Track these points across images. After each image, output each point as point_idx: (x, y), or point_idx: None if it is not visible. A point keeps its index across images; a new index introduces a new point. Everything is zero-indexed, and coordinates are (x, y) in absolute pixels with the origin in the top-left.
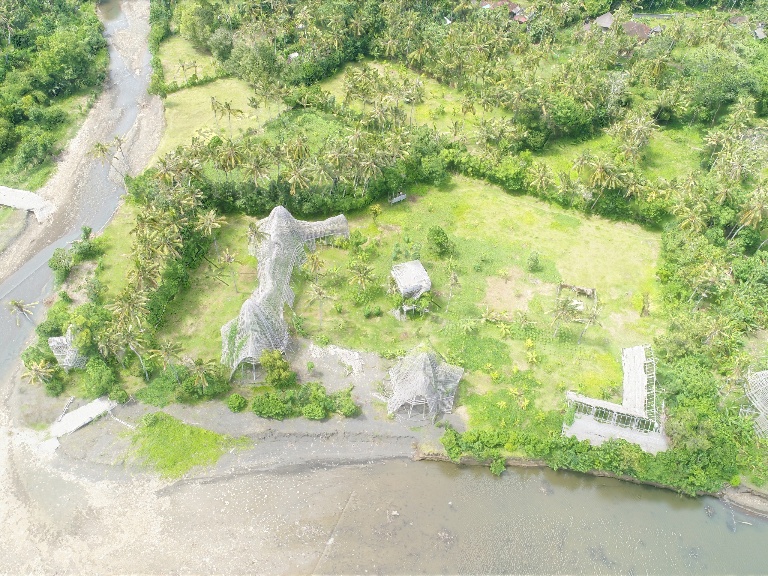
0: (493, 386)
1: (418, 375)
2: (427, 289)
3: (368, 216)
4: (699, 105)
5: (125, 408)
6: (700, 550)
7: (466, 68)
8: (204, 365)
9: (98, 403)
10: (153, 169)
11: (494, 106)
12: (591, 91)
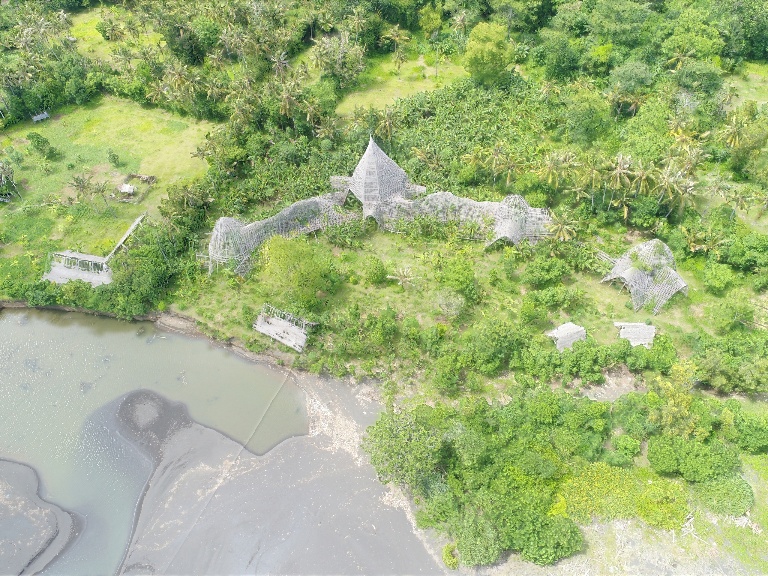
0: (23, 252)
1: None
2: None
3: (10, 133)
4: (337, 20)
5: None
6: (113, 357)
7: (153, 4)
8: None
9: None
10: None
11: None
12: (239, 14)
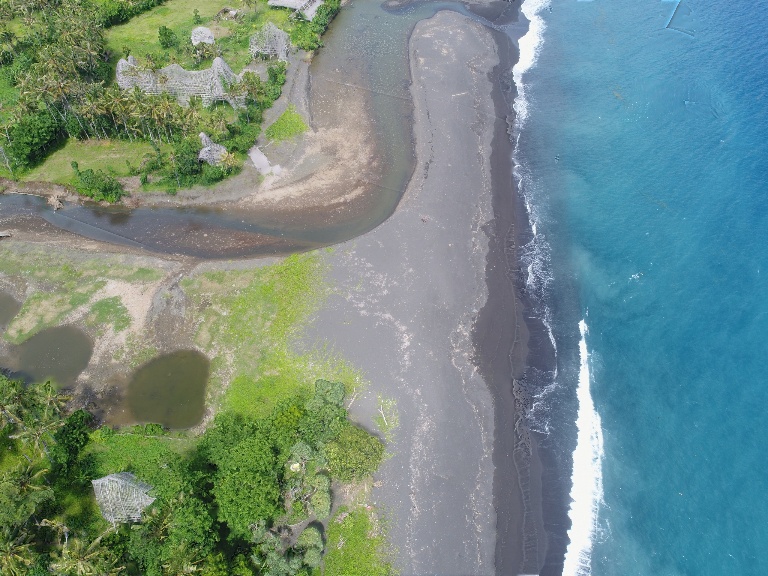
0: None
1: (278, 31)
2: (213, 35)
3: None
4: None
5: (259, 143)
6: None
7: None
8: (254, 83)
9: (252, 154)
10: (21, 122)
11: (10, 20)
12: None
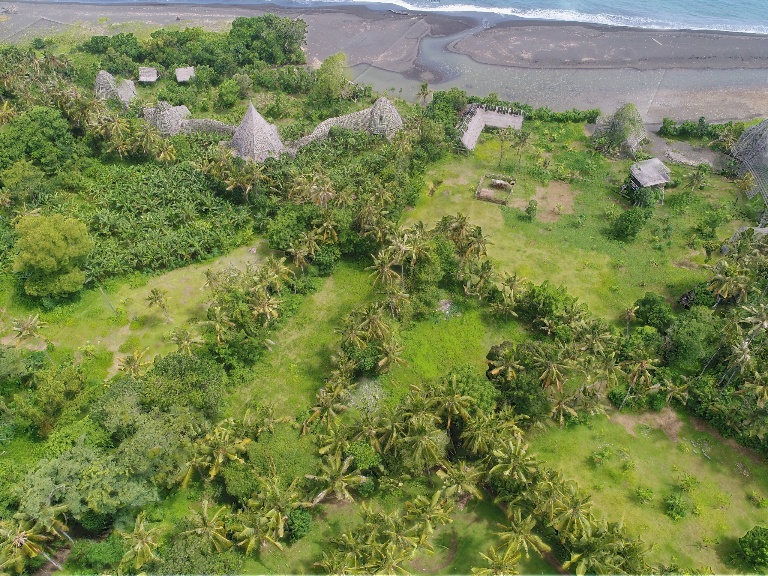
0: None
1: None
2: None
3: None
4: None
5: None
6: None
7: (654, 569)
8: None
9: None
10: None
11: None
12: None
